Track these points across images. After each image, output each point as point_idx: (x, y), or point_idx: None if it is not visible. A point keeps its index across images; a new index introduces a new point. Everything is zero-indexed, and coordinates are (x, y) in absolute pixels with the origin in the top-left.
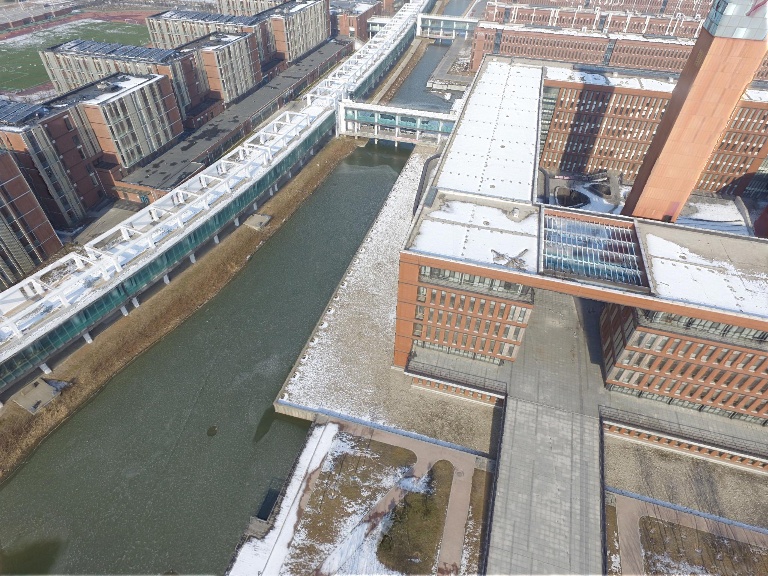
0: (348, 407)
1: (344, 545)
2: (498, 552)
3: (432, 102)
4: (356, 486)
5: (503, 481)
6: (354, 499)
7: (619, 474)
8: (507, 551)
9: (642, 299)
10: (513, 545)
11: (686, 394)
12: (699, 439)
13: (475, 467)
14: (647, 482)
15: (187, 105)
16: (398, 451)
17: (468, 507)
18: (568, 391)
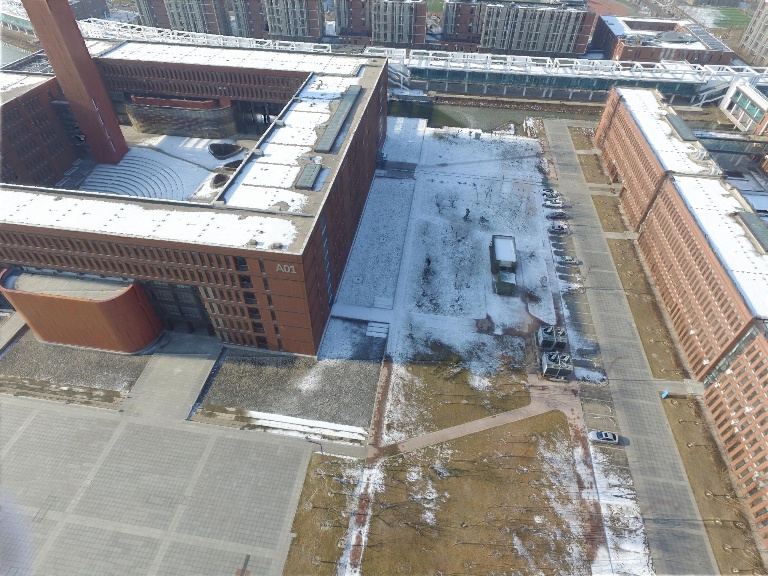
0: None
1: None
2: None
3: (479, 124)
4: None
5: None
6: None
7: None
8: None
9: None
10: None
11: None
12: None
13: None
14: None
15: (344, 27)
16: None
17: None
18: None
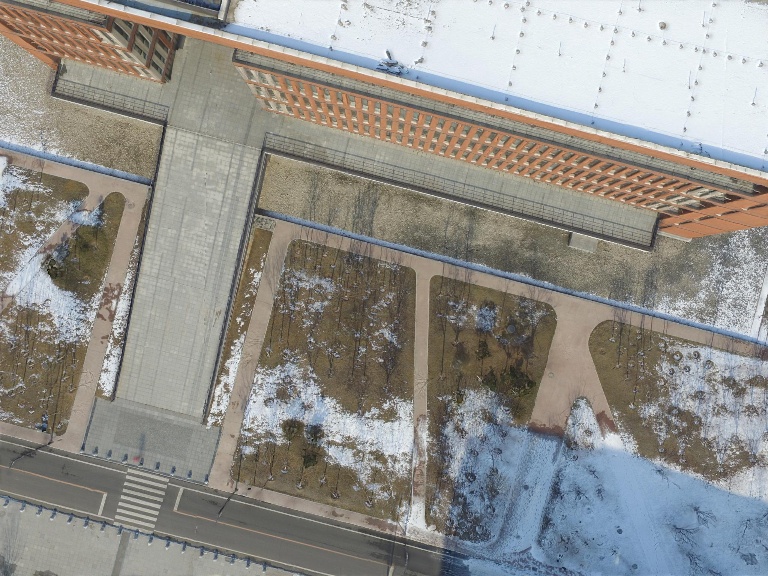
0: (17, 134)
1: (23, 273)
2: (146, 278)
3: None
4: (30, 221)
5: (155, 218)
6: (29, 233)
7: (290, 199)
8: (153, 277)
9: (202, 33)
10: (159, 272)
11: (343, 125)
12: (358, 170)
13: (146, 198)
14: (314, 206)
15: None
16: (70, 184)
17: (135, 237)
18: (237, 115)
